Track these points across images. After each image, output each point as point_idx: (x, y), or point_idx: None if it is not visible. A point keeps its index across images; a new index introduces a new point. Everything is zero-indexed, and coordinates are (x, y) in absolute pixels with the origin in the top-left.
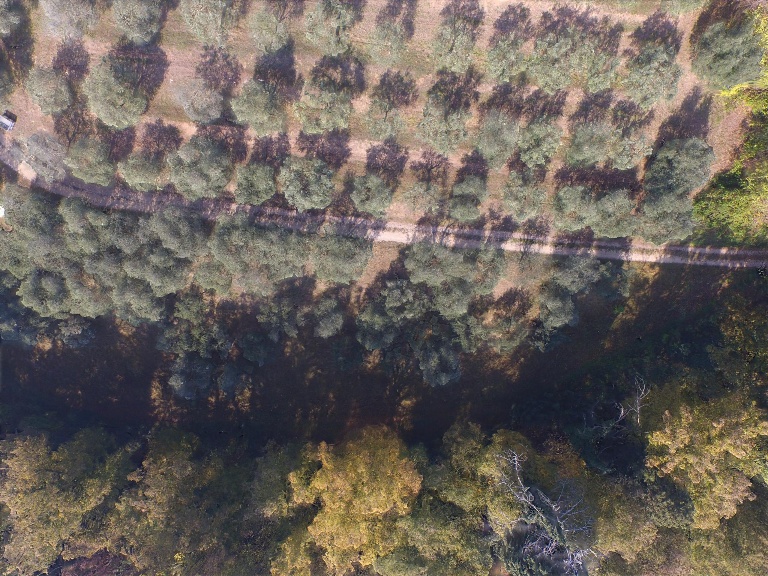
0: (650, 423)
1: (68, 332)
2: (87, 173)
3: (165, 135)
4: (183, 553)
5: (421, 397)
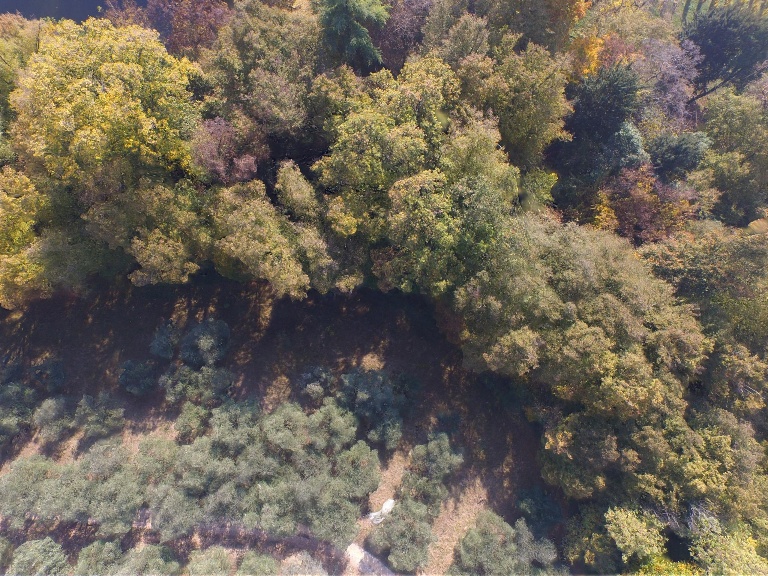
0: None
1: (312, 388)
2: (253, 571)
3: None
4: (103, 208)
5: (0, 323)
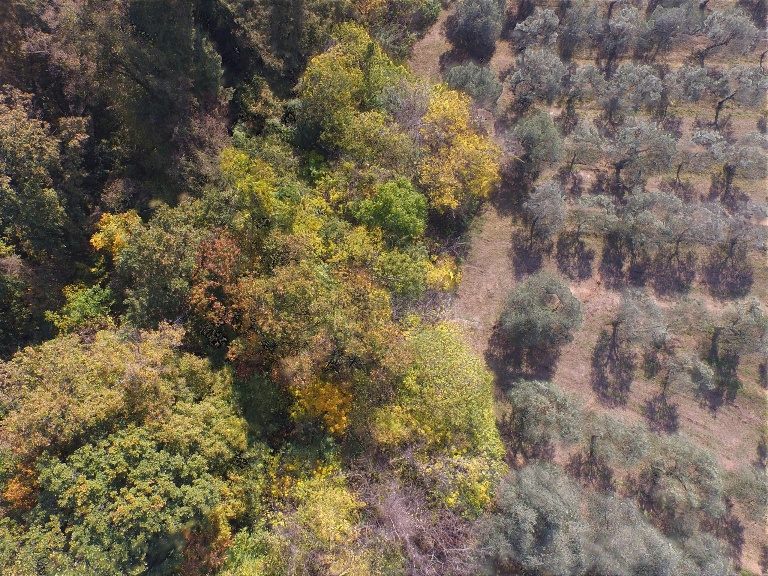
0: None
1: None
2: None
3: None
4: None
5: None
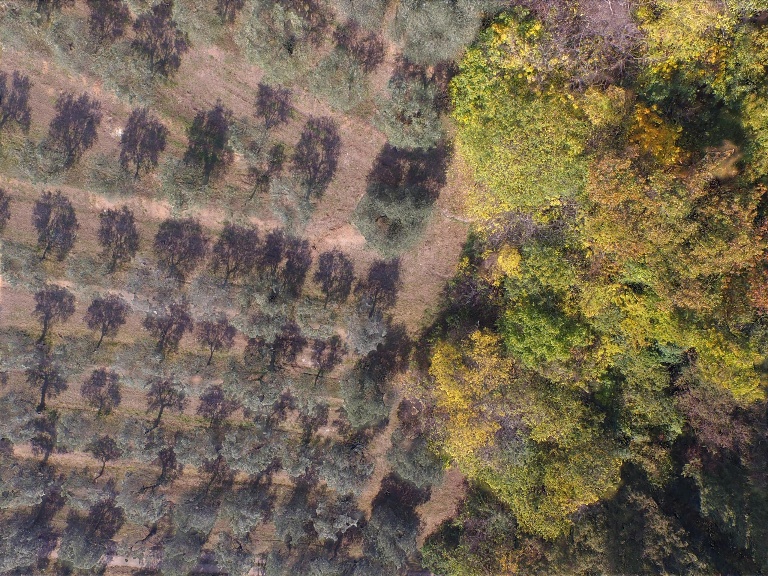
0: None
1: None
2: None
3: None
4: None
5: None
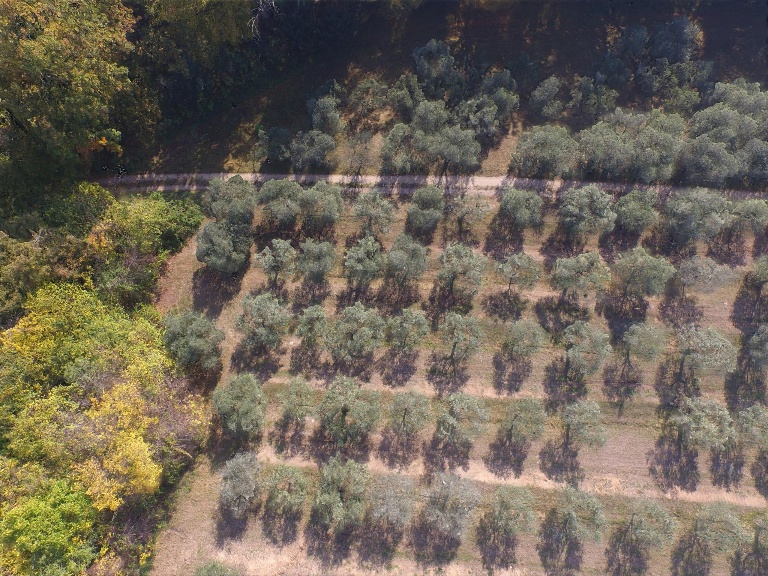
0: (240, 0)
1: None
2: None
3: (724, 258)
4: None
5: None
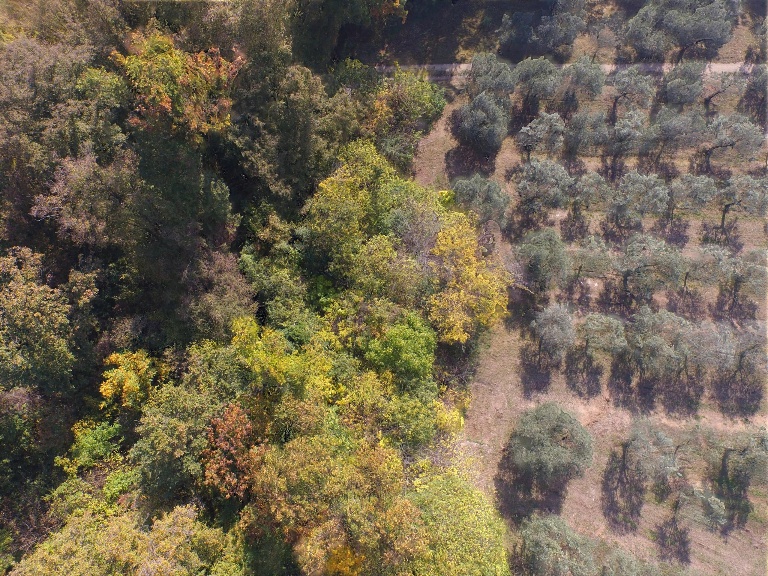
0: None
1: None
2: None
3: None
4: None
5: None
